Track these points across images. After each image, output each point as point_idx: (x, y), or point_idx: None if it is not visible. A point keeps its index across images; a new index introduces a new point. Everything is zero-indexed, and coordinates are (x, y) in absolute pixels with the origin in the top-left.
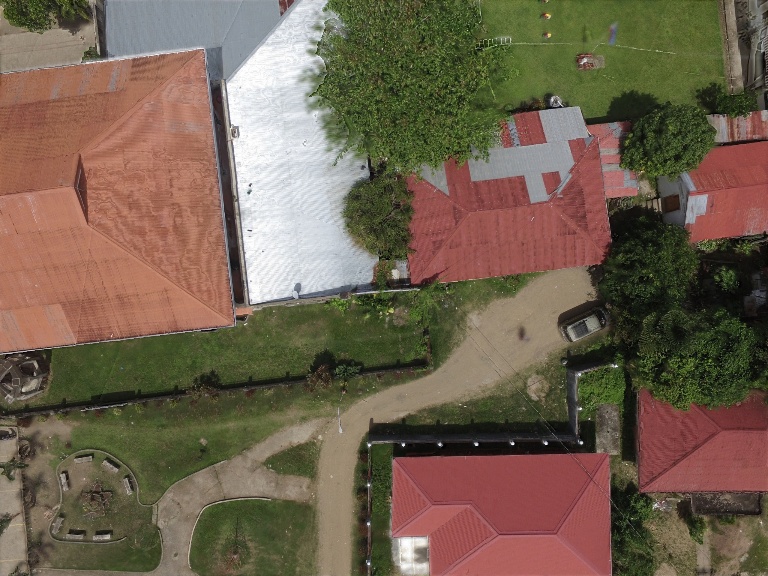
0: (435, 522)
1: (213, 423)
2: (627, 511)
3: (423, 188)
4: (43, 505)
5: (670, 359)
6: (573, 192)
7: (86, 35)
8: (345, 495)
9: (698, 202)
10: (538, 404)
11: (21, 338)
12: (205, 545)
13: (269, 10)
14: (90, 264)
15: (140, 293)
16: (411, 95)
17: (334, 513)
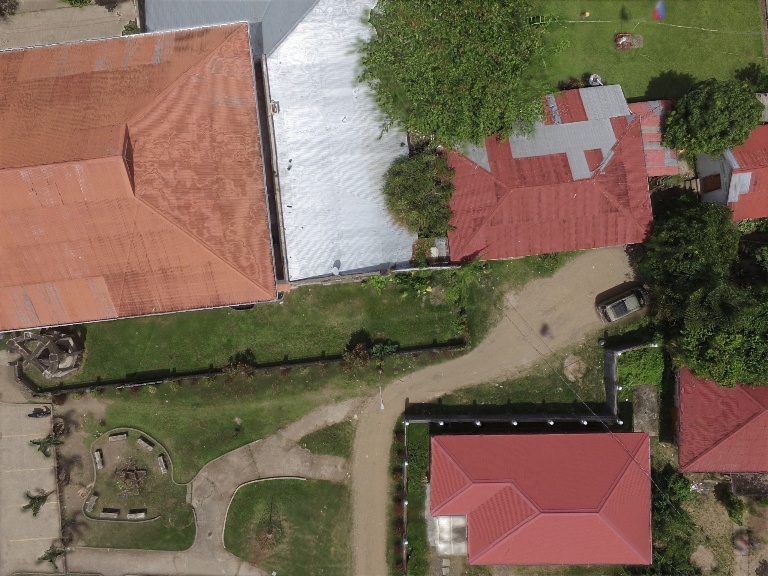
0: (475, 501)
1: (248, 402)
2: (666, 492)
3: (464, 165)
4: (77, 483)
5: (717, 335)
6: (615, 169)
7: (122, 11)
8: (380, 475)
9: (741, 180)
10: (575, 385)
11: (62, 311)
12: (239, 524)
13: None
14: (135, 236)
15: (184, 266)
16: (468, 61)
17: (369, 493)
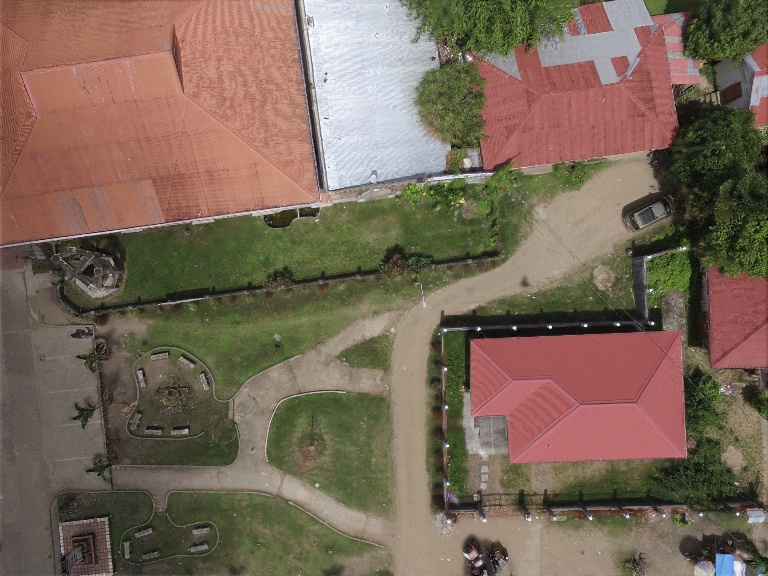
0: (515, 399)
1: (287, 319)
2: (697, 390)
3: (495, 74)
4: (120, 402)
5: (747, 223)
6: (642, 75)
7: None
8: (418, 386)
9: (763, 83)
10: (605, 294)
11: (111, 217)
12: (282, 438)
13: None
14: (183, 136)
15: (230, 167)
16: None
17: (408, 404)
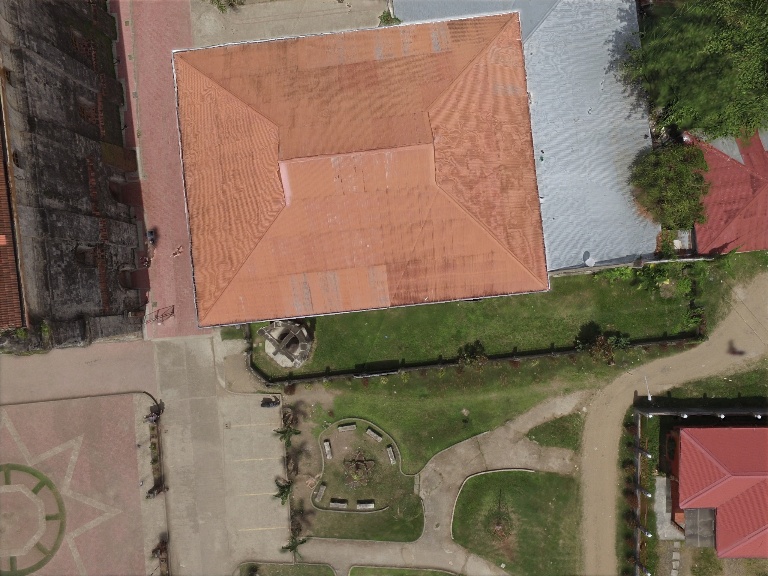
0: (729, 493)
1: (476, 393)
2: None
3: (716, 157)
4: (305, 473)
5: None
6: None
7: (353, 3)
8: (610, 468)
9: None
10: None
11: (337, 300)
12: (468, 516)
13: None
14: (427, 224)
15: (467, 255)
16: None
17: (598, 486)
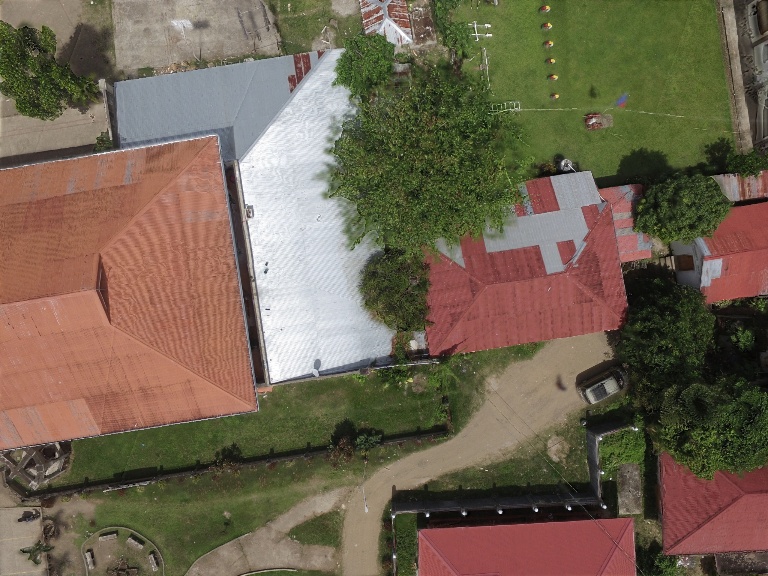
0: None
1: (236, 496)
2: (652, 572)
3: (439, 261)
4: None
5: (693, 431)
6: (588, 260)
7: (96, 113)
8: (370, 563)
9: (713, 266)
10: (559, 465)
11: (45, 432)
12: None
13: (279, 87)
14: (113, 360)
15: (163, 385)
16: (431, 198)
17: None
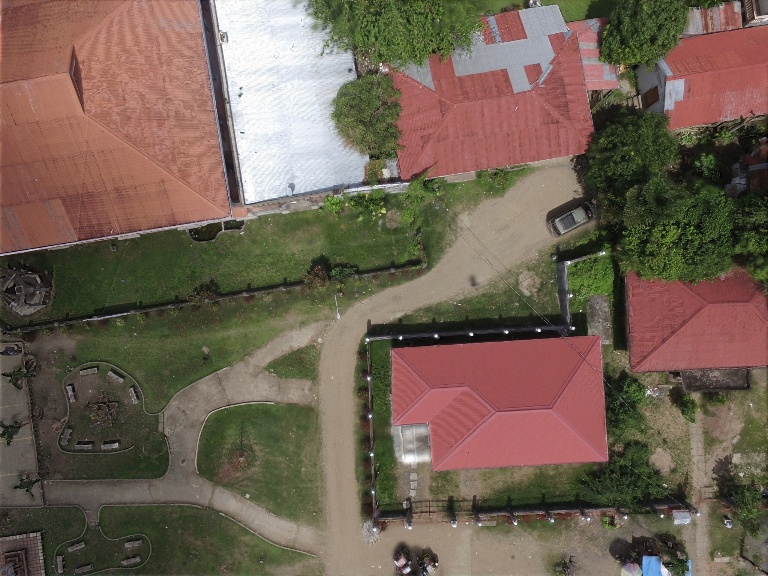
0: (434, 407)
1: (214, 331)
2: (620, 394)
3: (409, 85)
4: (51, 418)
5: (653, 228)
6: (554, 82)
7: None
8: (346, 395)
9: (675, 87)
10: (530, 299)
11: (23, 237)
12: (211, 450)
13: None
14: (88, 155)
15: (138, 185)
16: None
17: (336, 413)
